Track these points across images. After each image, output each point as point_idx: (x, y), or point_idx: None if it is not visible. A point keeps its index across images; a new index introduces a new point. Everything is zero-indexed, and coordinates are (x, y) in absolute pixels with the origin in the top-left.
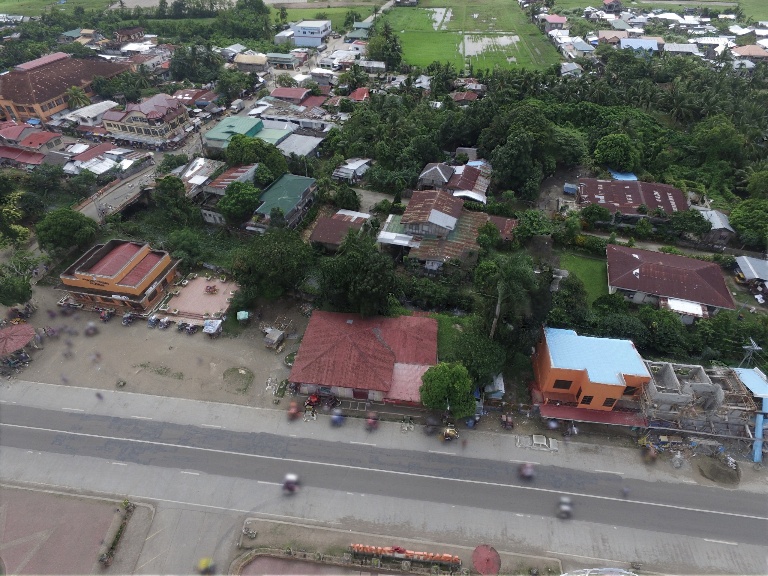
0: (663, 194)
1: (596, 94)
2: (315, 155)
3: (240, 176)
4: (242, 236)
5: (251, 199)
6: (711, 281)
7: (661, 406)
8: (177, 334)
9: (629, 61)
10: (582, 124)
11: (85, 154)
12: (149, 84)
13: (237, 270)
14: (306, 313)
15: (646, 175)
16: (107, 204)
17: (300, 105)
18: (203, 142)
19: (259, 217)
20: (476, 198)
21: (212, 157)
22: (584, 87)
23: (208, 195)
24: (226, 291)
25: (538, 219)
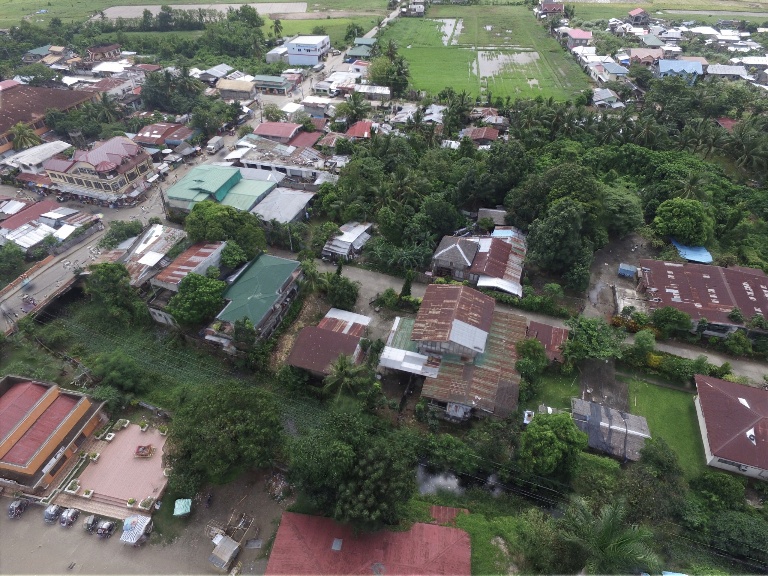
0: (756, 287)
1: (644, 134)
2: (303, 216)
3: (200, 262)
4: (201, 345)
5: (211, 300)
6: None
7: None
8: (86, 536)
9: (678, 91)
10: (628, 171)
11: (16, 217)
12: (113, 117)
13: (170, 452)
14: (277, 495)
15: (727, 255)
16: (28, 297)
17: (289, 145)
18: (165, 200)
19: (222, 324)
20: (509, 290)
21: (176, 219)
22: (628, 125)
23: (158, 288)
24: None
25: (598, 333)
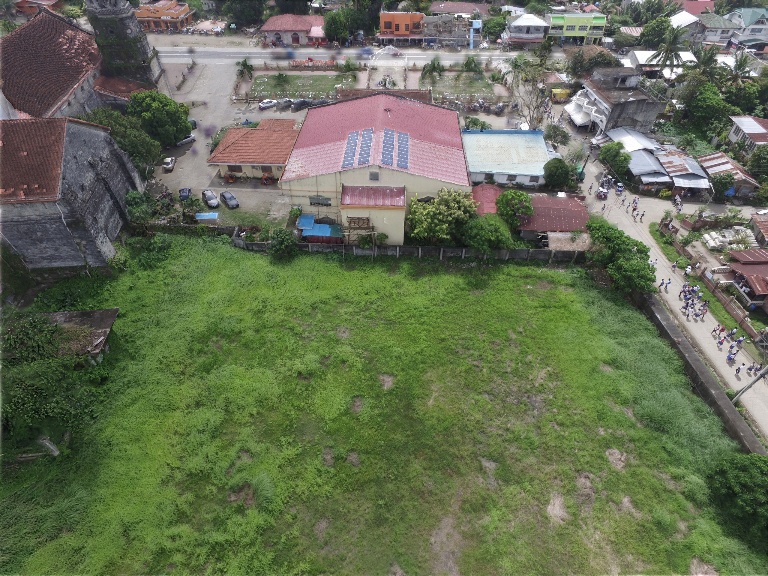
0: None
1: None
2: None
3: None
4: None
5: None
6: (478, 7)
7: (429, 27)
8: (199, 36)
9: None
10: None
11: None
12: None
13: None
14: None
15: None
16: None
17: None
18: None
19: None
20: None
21: None
22: None
23: None
24: (222, 24)
25: None
